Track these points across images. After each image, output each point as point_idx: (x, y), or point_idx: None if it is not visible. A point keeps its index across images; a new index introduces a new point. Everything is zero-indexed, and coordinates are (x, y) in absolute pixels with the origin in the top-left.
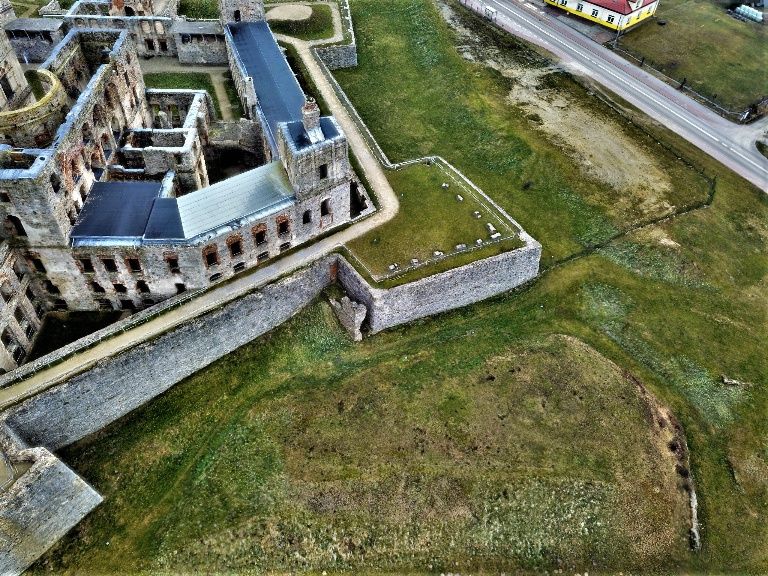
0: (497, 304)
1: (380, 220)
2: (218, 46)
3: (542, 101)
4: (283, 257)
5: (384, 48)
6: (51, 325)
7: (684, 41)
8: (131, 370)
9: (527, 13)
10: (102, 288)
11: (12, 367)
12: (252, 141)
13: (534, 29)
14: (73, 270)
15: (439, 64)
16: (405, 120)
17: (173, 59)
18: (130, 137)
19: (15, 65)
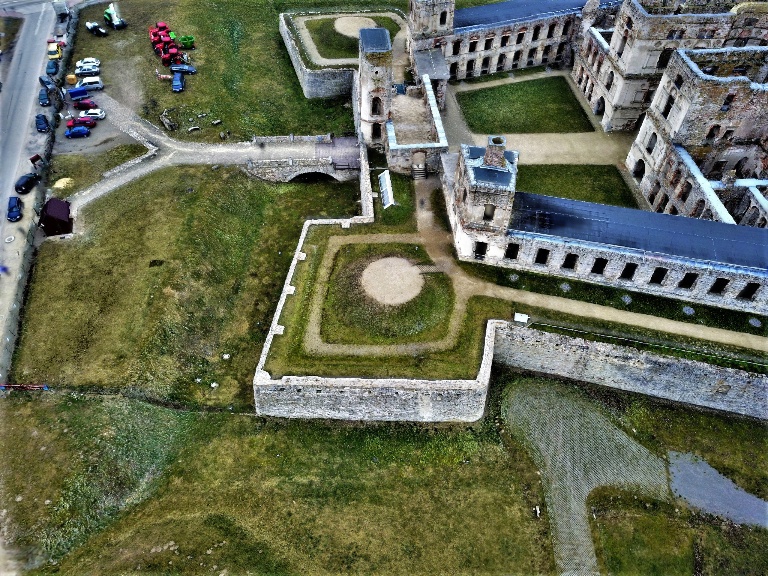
0: None
1: None
2: None
3: None
4: None
5: None
6: None
7: None
8: None
9: None
10: None
11: None
12: None
13: None
14: None
15: None
16: None
17: None
18: None
19: None
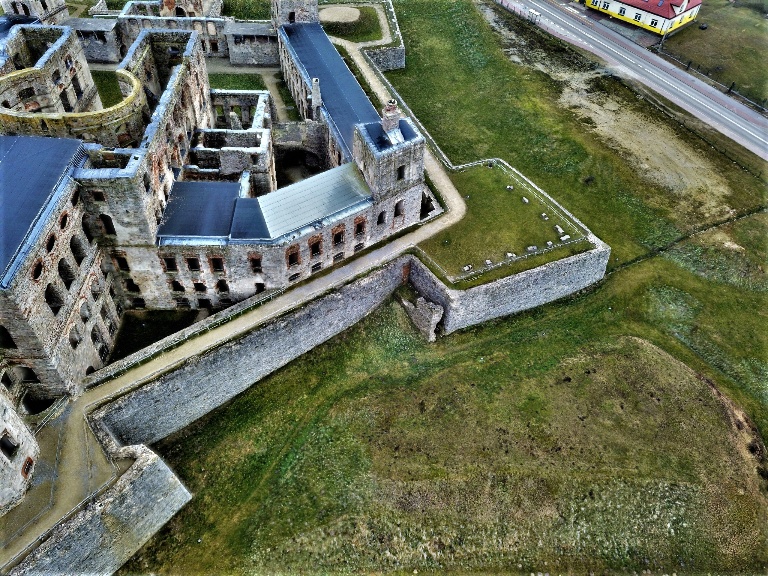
0: (565, 306)
1: (449, 221)
2: (270, 47)
3: (593, 104)
4: (357, 257)
5: (430, 50)
6: (130, 323)
7: (727, 45)
8: (218, 369)
9: (569, 16)
10: (182, 287)
11: (98, 365)
12: (316, 142)
13: (578, 32)
14: (156, 269)
15: (487, 67)
16: (458, 122)
17: (224, 60)
18: (201, 137)
19: (84, 65)
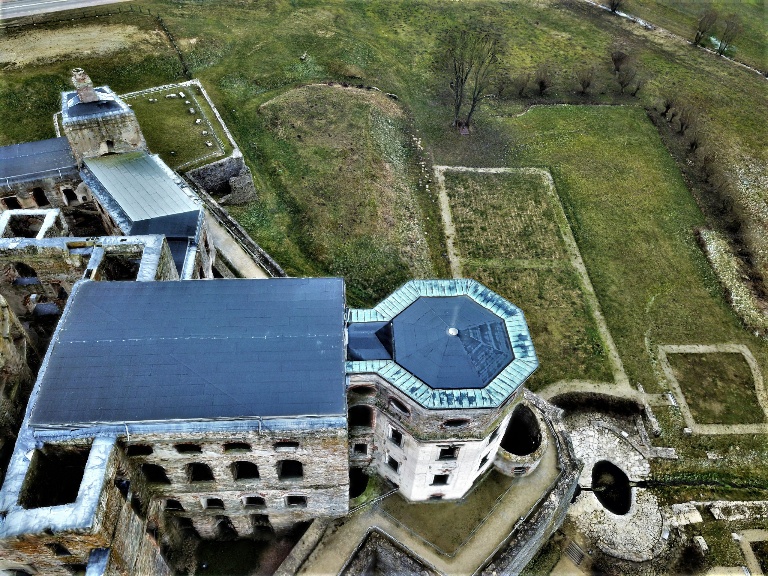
0: None
1: None
2: None
3: None
4: None
5: None
6: None
7: None
8: None
9: None
10: None
11: None
12: None
13: None
14: None
15: None
16: None
17: None
18: None
19: None
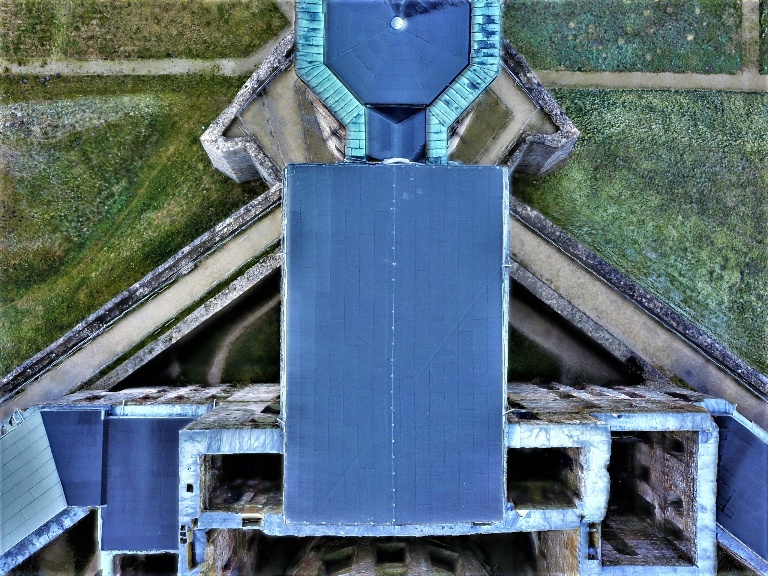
0: None
1: None
2: None
3: None
4: None
5: None
6: None
7: None
8: None
9: None
10: None
11: None
12: None
13: None
14: None
15: None
16: None
17: None
18: None
19: None
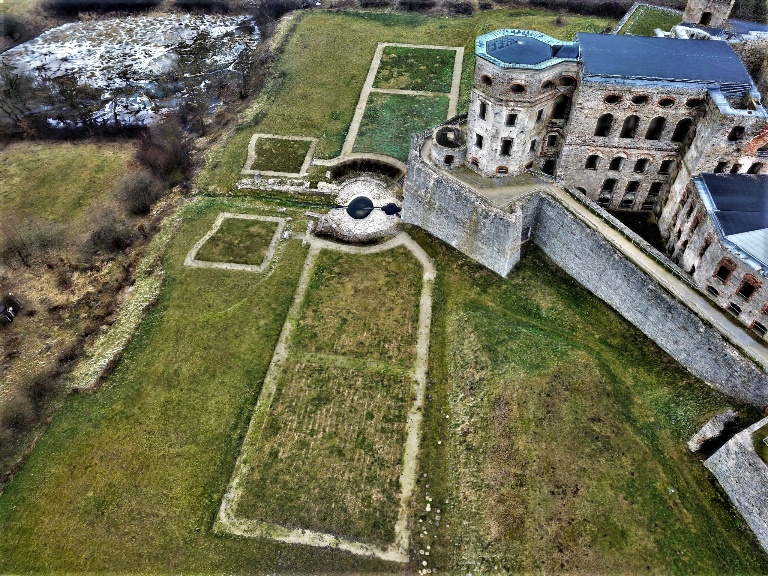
0: None
1: None
2: None
3: None
4: None
5: None
6: (640, 216)
7: None
8: (598, 255)
9: None
10: None
11: None
12: None
13: None
14: (680, 196)
15: None
16: None
17: None
18: None
19: None
